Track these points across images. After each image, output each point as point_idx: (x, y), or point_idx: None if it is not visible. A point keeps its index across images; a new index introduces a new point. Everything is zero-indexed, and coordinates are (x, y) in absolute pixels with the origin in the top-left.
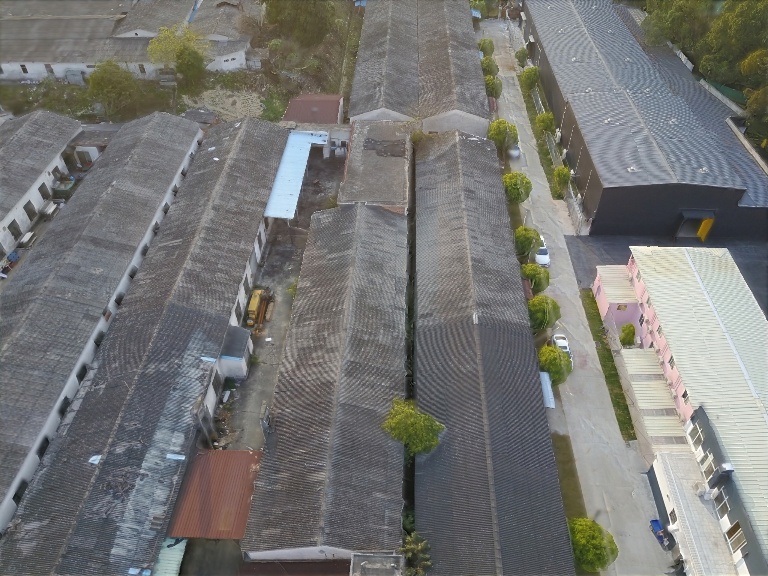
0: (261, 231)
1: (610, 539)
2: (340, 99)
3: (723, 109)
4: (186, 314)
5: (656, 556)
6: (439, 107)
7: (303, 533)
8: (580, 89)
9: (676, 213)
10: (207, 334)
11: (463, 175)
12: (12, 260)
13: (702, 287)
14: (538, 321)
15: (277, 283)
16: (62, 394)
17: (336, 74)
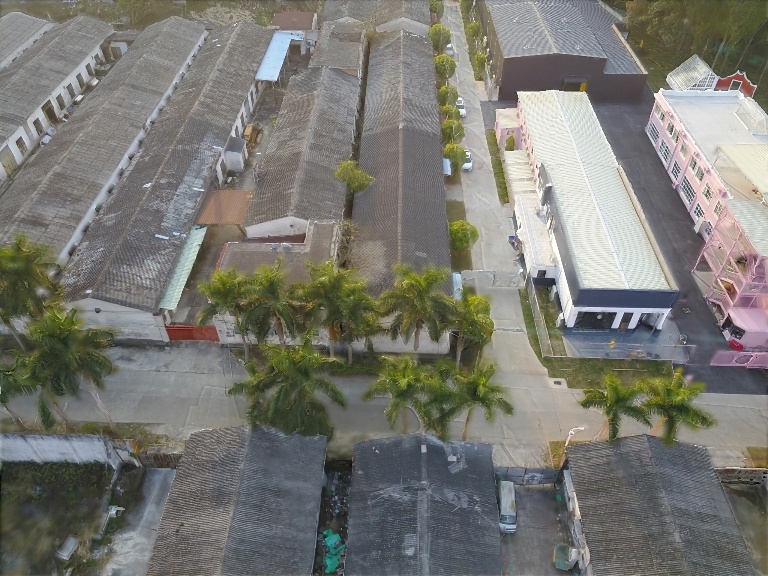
0: (253, 91)
1: (473, 227)
2: (314, 13)
3: (612, 20)
4: (201, 124)
5: (509, 253)
6: (391, 17)
7: (280, 213)
8: (501, 4)
9: (560, 80)
10: (216, 135)
11: (403, 54)
12: (70, 111)
13: (560, 109)
14: (447, 135)
15: (265, 124)
16: (120, 165)
17: (313, 3)
